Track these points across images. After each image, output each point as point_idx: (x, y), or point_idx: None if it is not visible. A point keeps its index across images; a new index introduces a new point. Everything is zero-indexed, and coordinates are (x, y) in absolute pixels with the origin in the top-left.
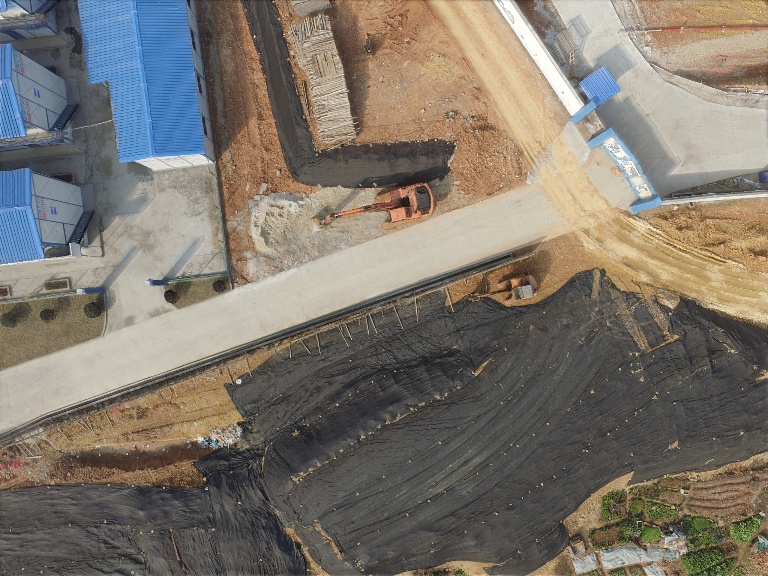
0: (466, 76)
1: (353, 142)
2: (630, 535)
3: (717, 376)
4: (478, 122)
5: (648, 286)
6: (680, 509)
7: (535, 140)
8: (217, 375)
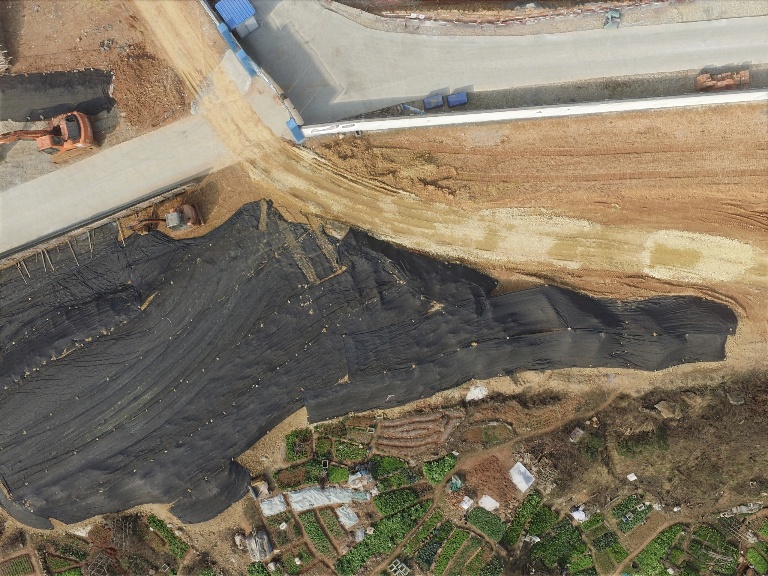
0: (122, 4)
1: (8, 72)
2: (317, 475)
3: (386, 308)
4: (134, 51)
5: (316, 217)
6: (368, 448)
7: (196, 69)
8: None
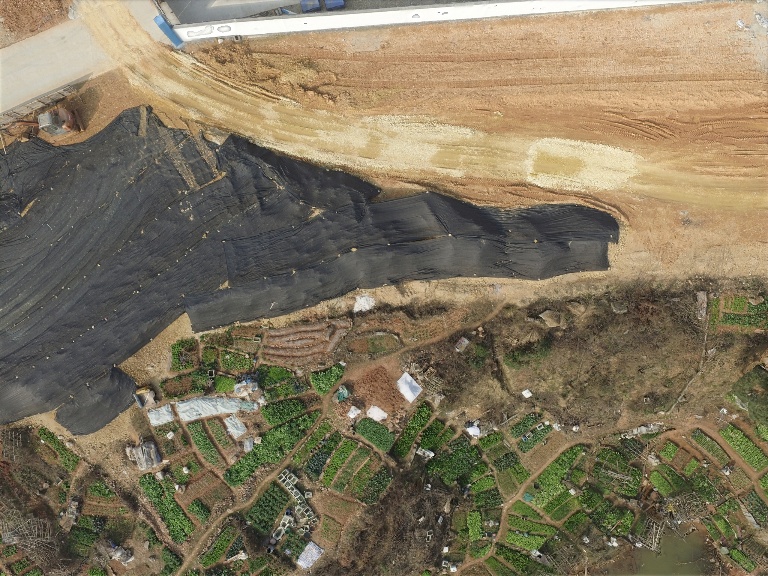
0: None
1: None
2: (203, 385)
3: (266, 213)
4: None
5: (196, 123)
6: (255, 358)
7: None
8: None
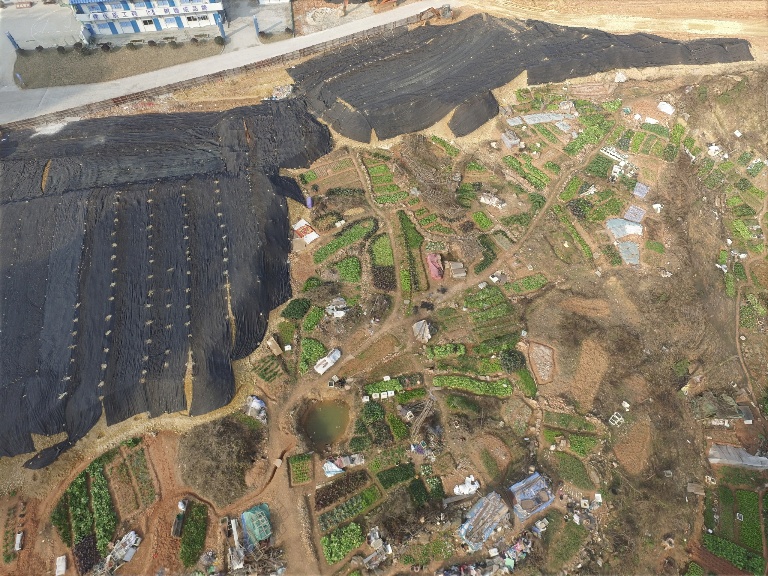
0: None
1: None
2: None
3: None
4: None
5: (511, 16)
6: None
7: None
8: (281, 66)
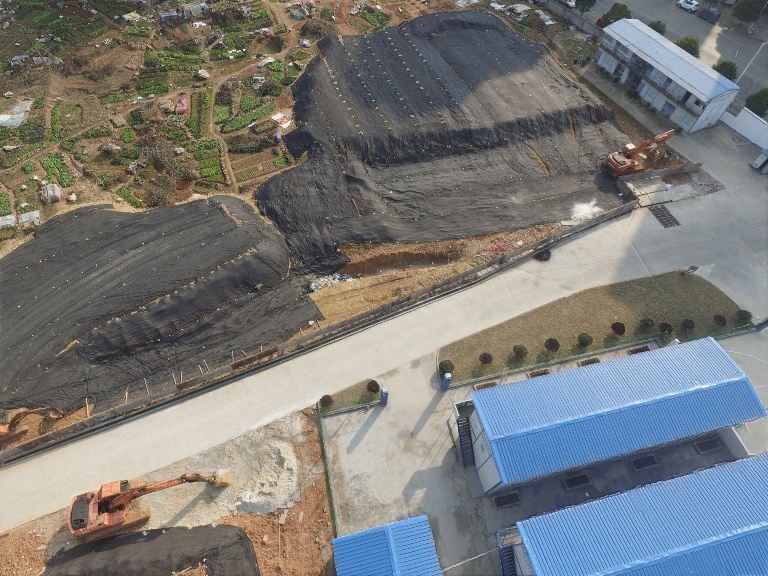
0: None
1: None
2: None
3: None
4: None
5: None
6: None
7: None
8: None
